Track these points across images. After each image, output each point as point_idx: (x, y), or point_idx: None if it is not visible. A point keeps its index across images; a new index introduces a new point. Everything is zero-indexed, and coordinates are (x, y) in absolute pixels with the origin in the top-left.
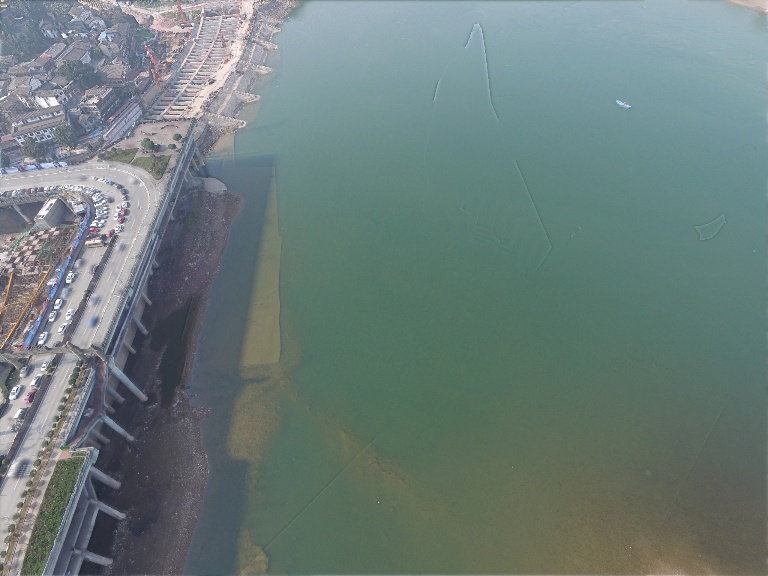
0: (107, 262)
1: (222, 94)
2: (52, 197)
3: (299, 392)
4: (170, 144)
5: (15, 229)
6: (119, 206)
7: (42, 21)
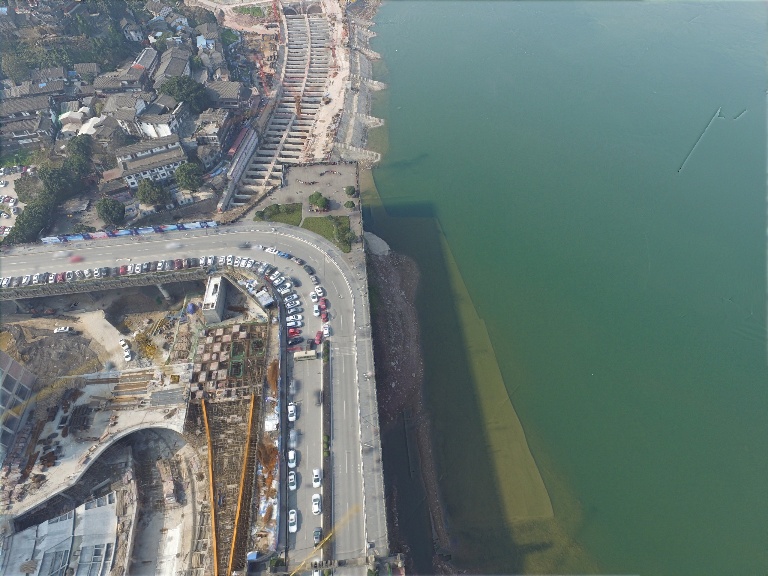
0: (331, 385)
1: (345, 118)
2: (214, 275)
3: (599, 566)
4: (349, 202)
5: (148, 306)
6: (314, 294)
7: (124, 20)
